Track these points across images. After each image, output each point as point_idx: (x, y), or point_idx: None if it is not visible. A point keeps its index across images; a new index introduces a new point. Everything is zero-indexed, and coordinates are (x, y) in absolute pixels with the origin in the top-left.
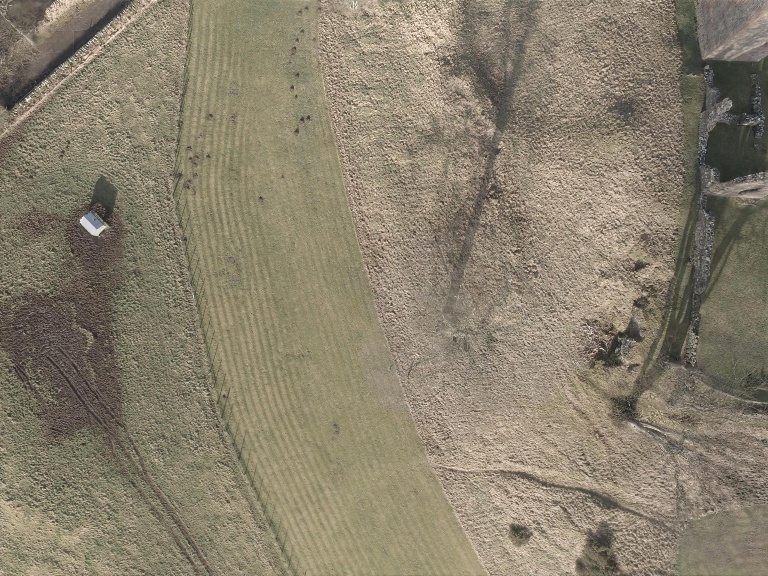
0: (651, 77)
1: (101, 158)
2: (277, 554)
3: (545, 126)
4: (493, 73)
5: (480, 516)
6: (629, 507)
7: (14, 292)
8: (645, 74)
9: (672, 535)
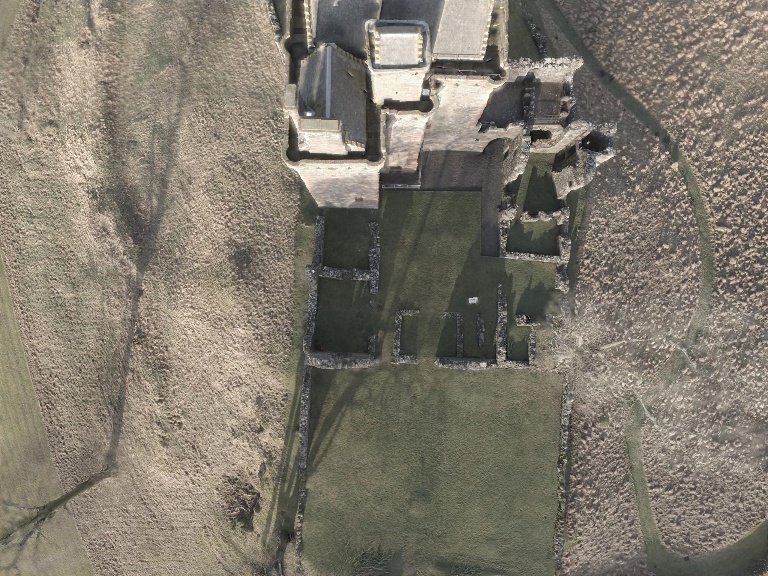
0: (269, 224)
1: None
2: None
3: (181, 269)
4: (140, 208)
5: None
6: None
7: None
8: (264, 221)
9: None
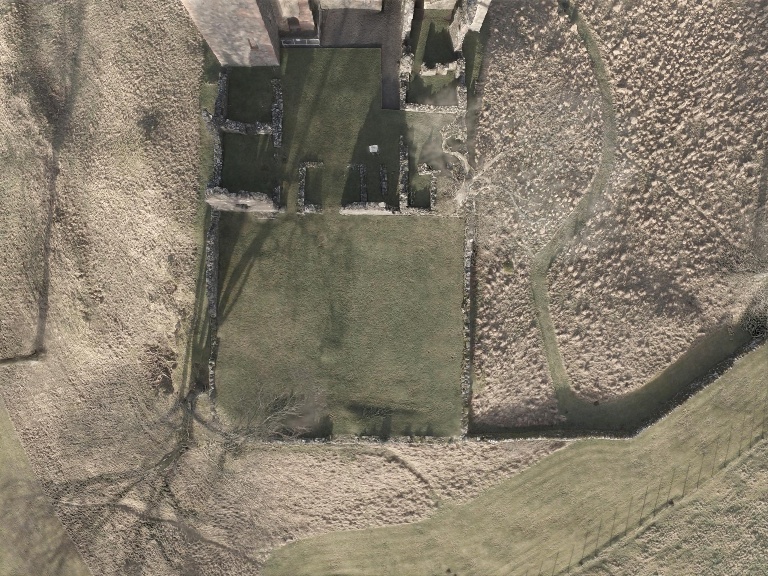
0: (175, 87)
1: None
2: None
3: (95, 143)
4: (54, 89)
5: (100, 551)
6: (211, 539)
7: None
8: (170, 84)
9: (253, 567)
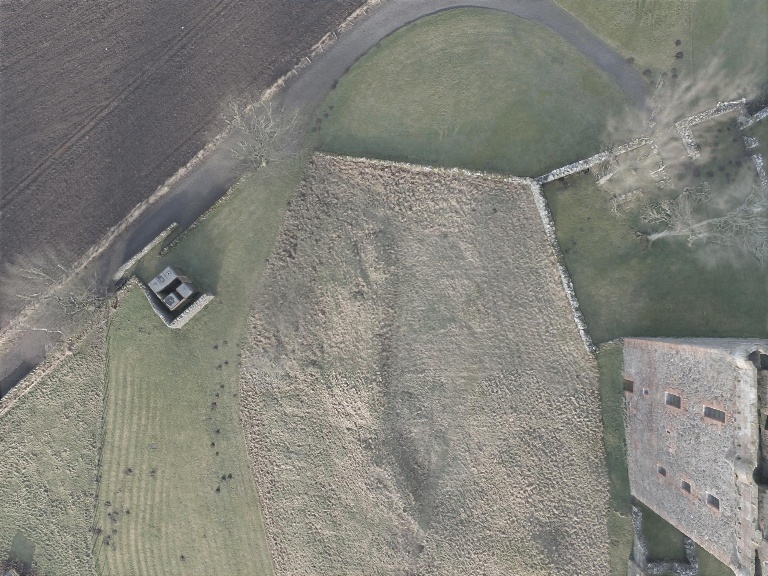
0: (577, 507)
1: (18, 512)
2: None
3: (469, 533)
4: (416, 461)
5: None
6: None
7: None
8: (571, 502)
9: None
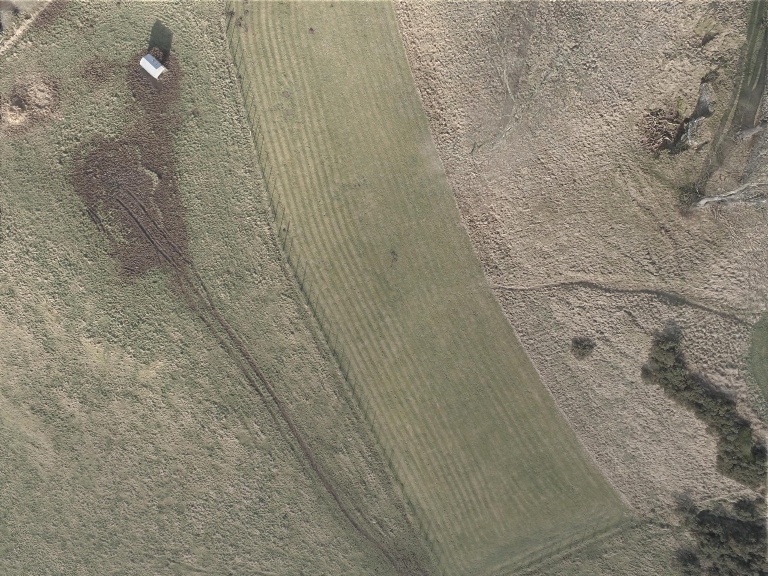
0: None
1: (156, 2)
2: (341, 383)
3: None
4: None
5: (541, 334)
6: (698, 303)
7: (83, 138)
8: None
9: (744, 327)
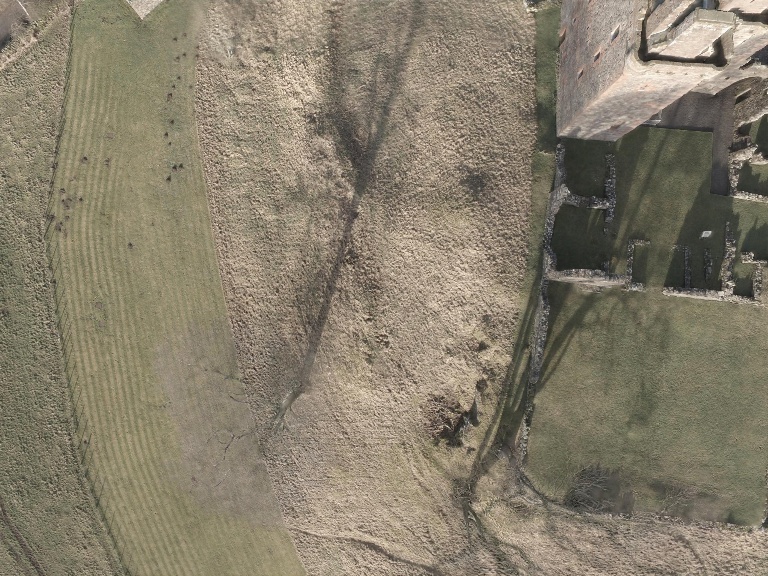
0: (504, 151)
1: None
2: None
3: (402, 193)
4: (358, 134)
5: None
6: None
7: None
8: (499, 148)
9: None
